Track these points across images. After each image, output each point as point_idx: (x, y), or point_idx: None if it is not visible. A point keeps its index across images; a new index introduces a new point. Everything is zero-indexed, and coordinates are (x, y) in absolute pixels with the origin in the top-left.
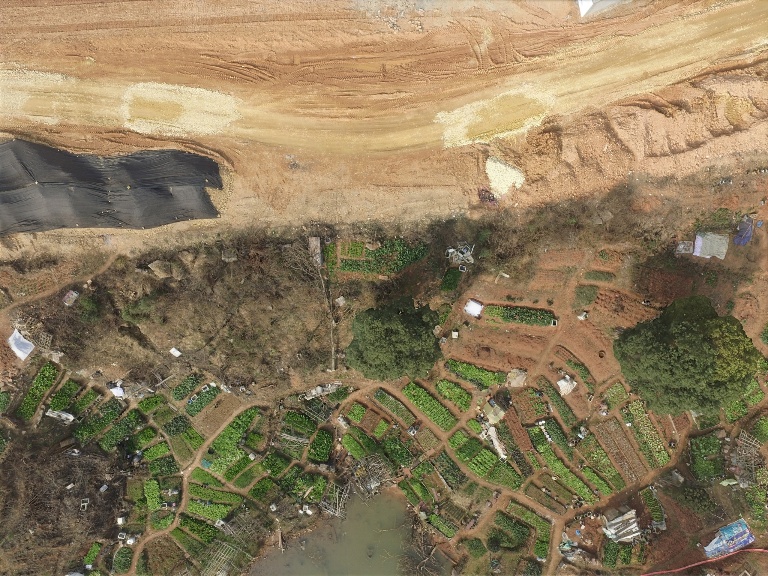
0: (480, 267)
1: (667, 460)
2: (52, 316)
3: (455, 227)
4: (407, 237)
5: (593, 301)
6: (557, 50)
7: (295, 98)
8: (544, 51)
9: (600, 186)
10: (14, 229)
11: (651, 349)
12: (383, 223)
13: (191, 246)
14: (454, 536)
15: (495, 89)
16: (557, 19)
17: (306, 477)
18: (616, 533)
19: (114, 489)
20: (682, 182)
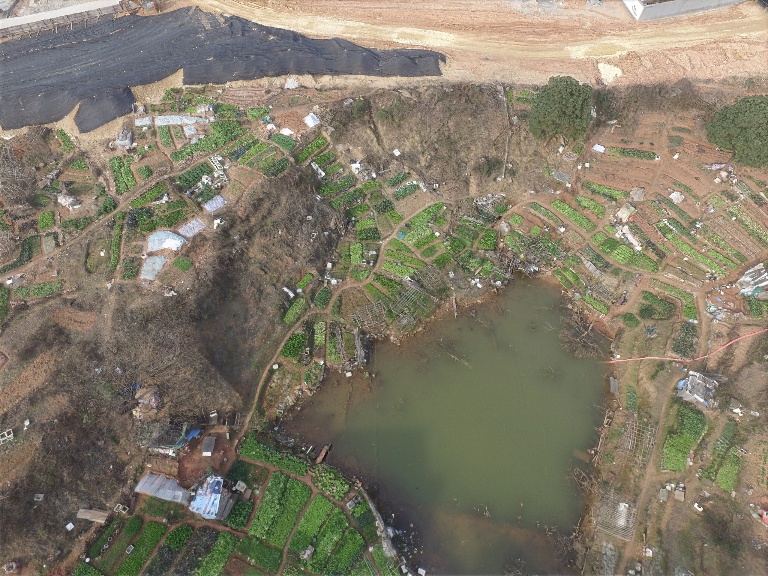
0: (601, 120)
1: None
2: (335, 109)
3: None
4: None
5: (681, 145)
6: (627, 30)
7: (487, 36)
8: (620, 30)
9: (669, 80)
10: (322, 74)
11: None
12: (539, 86)
13: None
14: (607, 314)
15: (596, 41)
16: (624, 21)
17: (477, 258)
18: (753, 280)
19: (331, 240)
20: (719, 82)
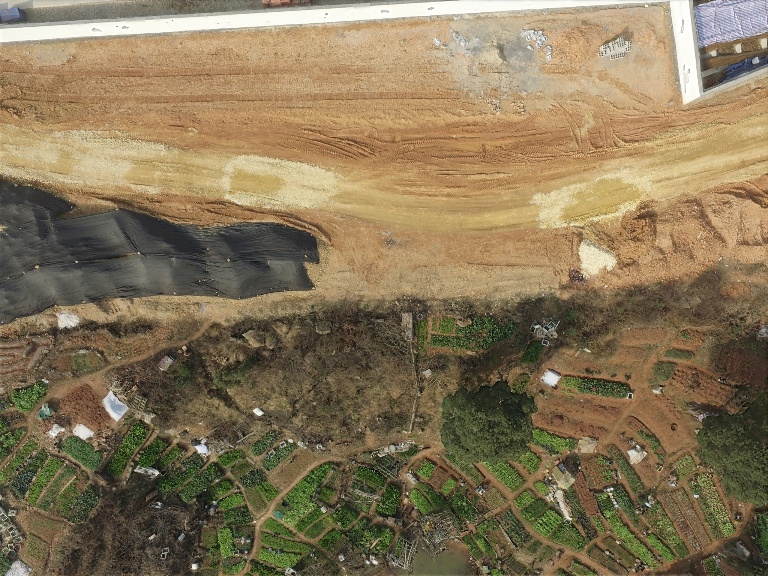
0: (563, 342)
1: (732, 532)
2: (147, 380)
3: (543, 305)
4: (497, 314)
5: (670, 377)
6: (657, 136)
7: (394, 176)
8: (644, 137)
9: (690, 271)
10: (112, 294)
11: (743, 446)
12: (474, 300)
13: (285, 316)
14: None
15: (593, 173)
16: (658, 105)
17: (374, 529)
18: None
19: (190, 537)
20: None
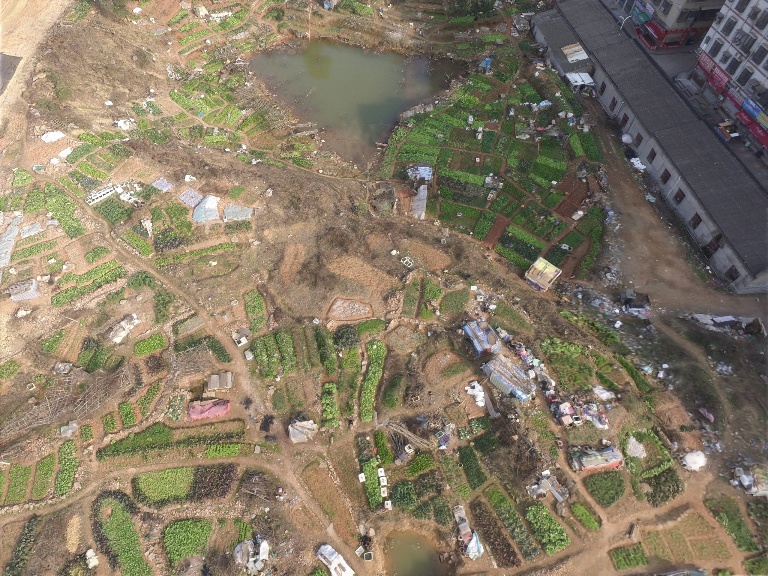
0: None
1: None
2: None
3: None
4: None
5: None
6: None
7: None
8: None
9: None
10: None
11: None
12: None
13: None
14: None
15: None
16: None
17: None
18: None
19: None
20: None
